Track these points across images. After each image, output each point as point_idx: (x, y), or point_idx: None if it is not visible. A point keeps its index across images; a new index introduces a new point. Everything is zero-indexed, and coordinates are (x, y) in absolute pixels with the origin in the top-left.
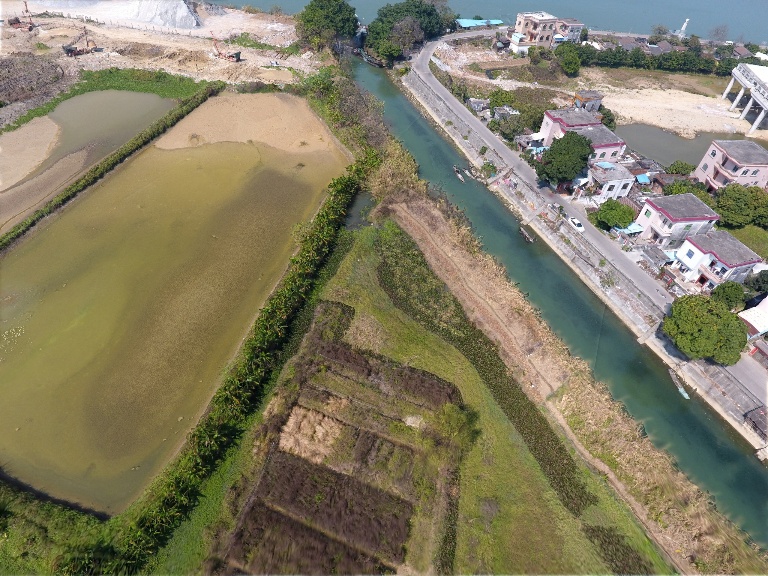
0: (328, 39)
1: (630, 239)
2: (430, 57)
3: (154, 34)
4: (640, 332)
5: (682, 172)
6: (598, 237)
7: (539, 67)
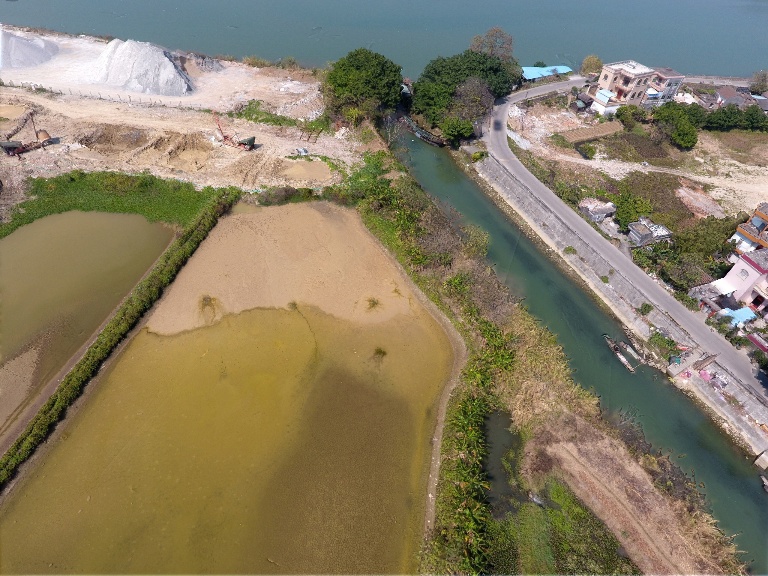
0: (370, 111)
1: None
2: (506, 132)
3: (131, 107)
4: None
5: None
6: None
7: (636, 135)
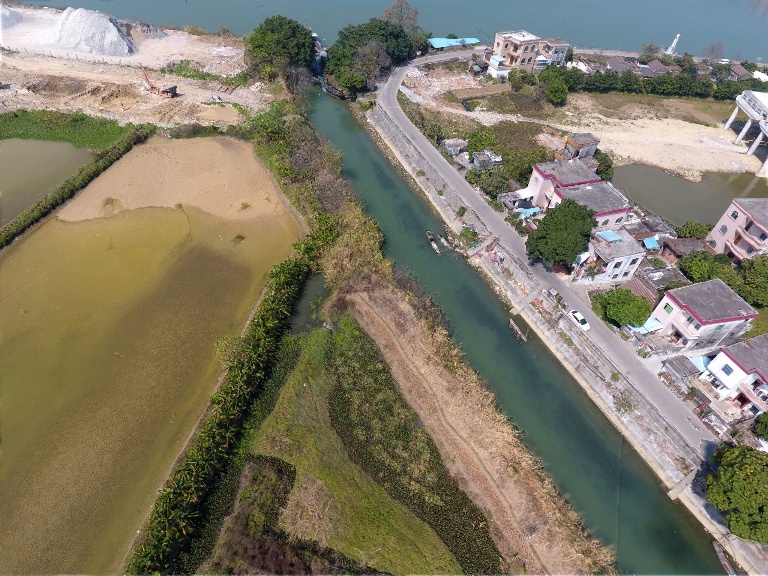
0: (280, 68)
1: (646, 337)
2: (398, 87)
3: (77, 64)
4: (671, 481)
5: (697, 236)
6: (607, 337)
7: (521, 94)
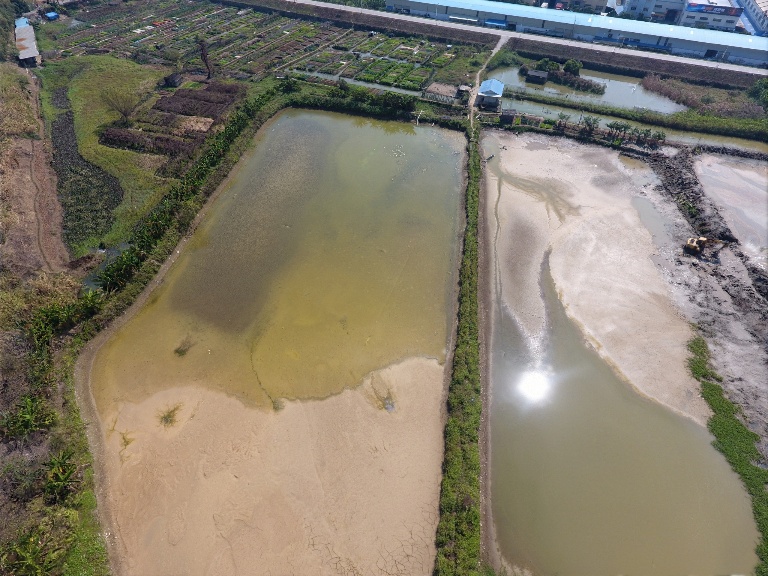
0: None
1: None
2: None
3: None
4: None
5: None
6: None
7: None
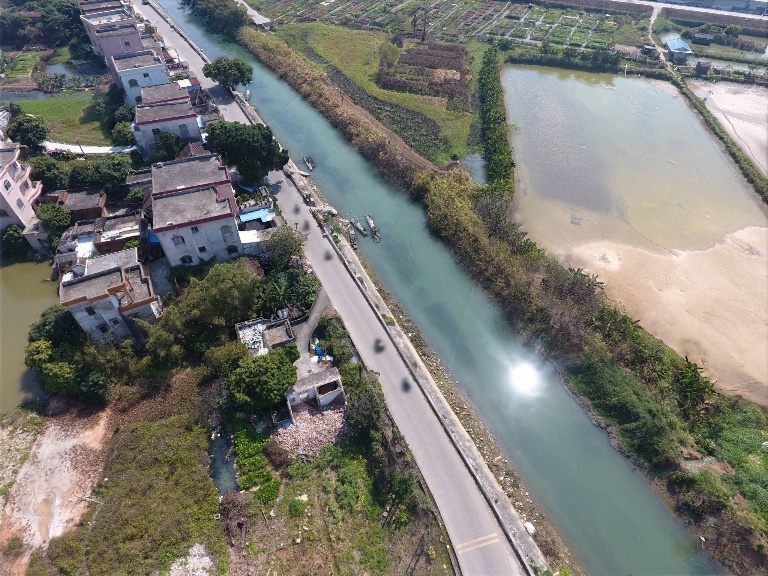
0: None
1: None
2: None
3: None
4: (253, 110)
5: None
6: None
7: None
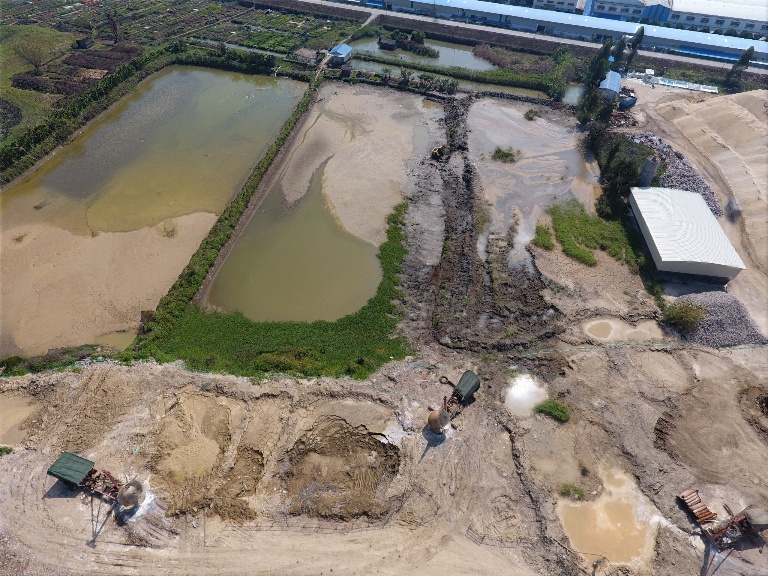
0: None
1: None
2: None
3: None
4: None
5: None
6: None
7: None
